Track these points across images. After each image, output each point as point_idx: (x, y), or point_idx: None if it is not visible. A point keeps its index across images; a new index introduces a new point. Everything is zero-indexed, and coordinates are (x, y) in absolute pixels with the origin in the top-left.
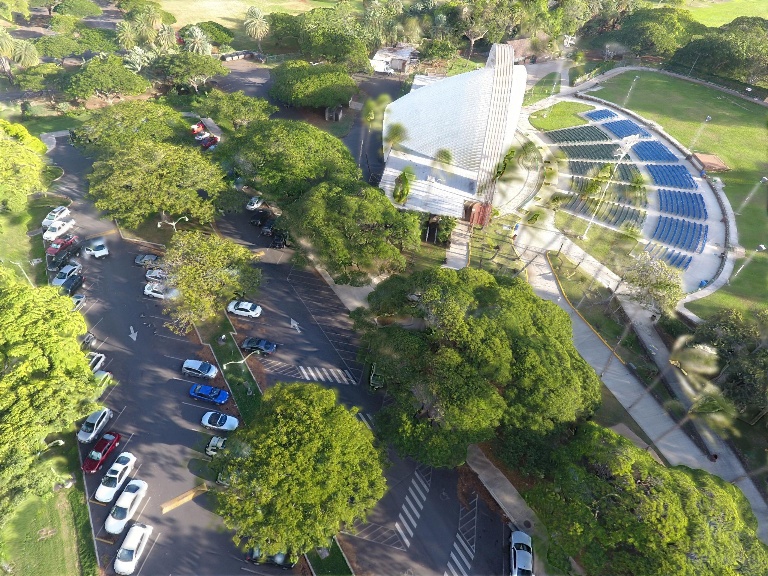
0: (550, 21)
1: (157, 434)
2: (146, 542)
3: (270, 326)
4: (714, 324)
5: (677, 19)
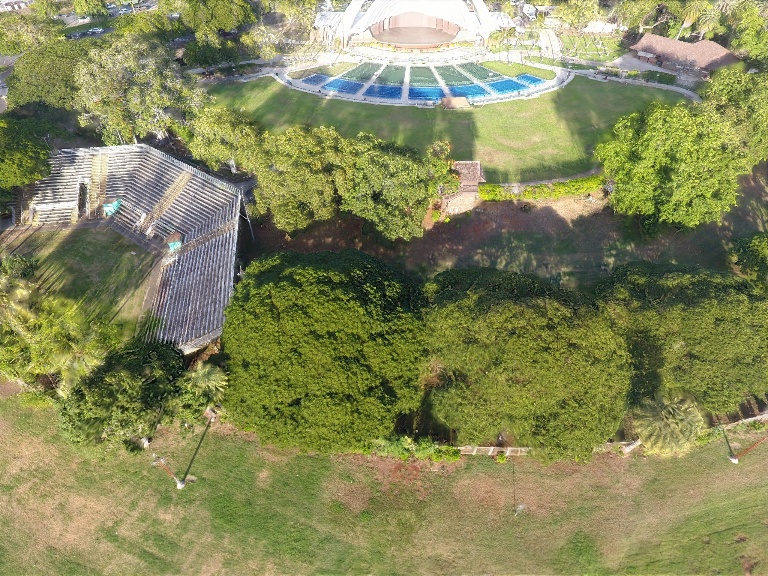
0: (743, 38)
1: None
2: (176, 16)
3: None
4: None
5: None
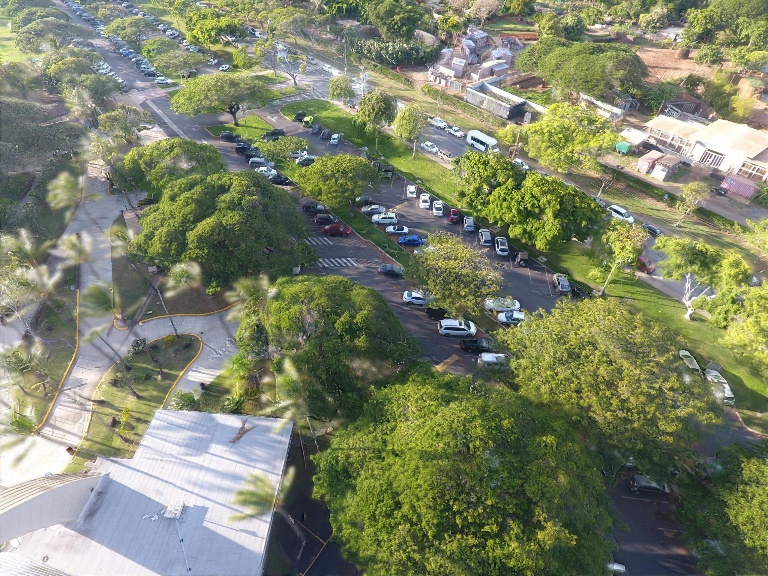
0: None
1: (431, 225)
2: None
3: (391, 290)
4: (4, 240)
5: None
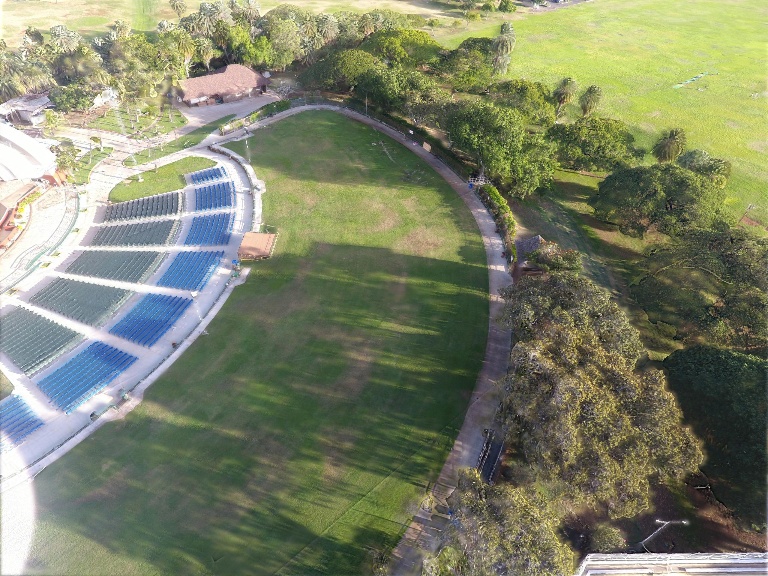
0: (251, 52)
1: None
2: None
3: None
4: None
5: (401, 43)
